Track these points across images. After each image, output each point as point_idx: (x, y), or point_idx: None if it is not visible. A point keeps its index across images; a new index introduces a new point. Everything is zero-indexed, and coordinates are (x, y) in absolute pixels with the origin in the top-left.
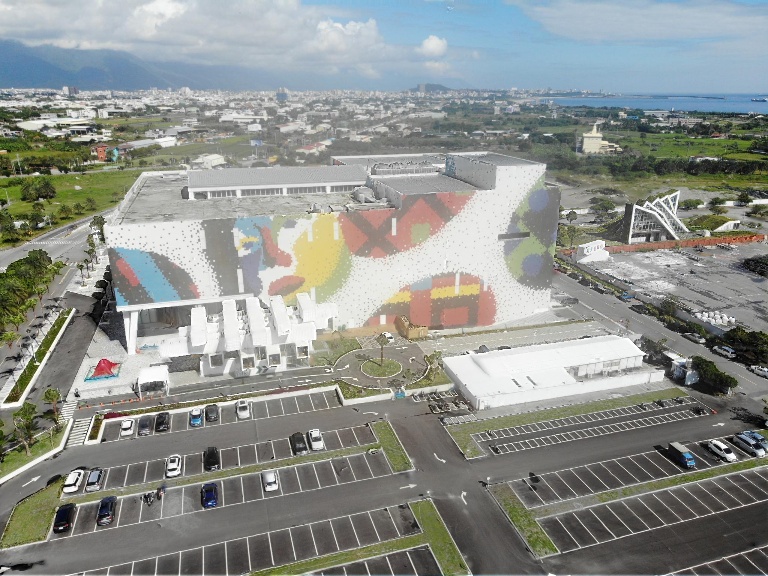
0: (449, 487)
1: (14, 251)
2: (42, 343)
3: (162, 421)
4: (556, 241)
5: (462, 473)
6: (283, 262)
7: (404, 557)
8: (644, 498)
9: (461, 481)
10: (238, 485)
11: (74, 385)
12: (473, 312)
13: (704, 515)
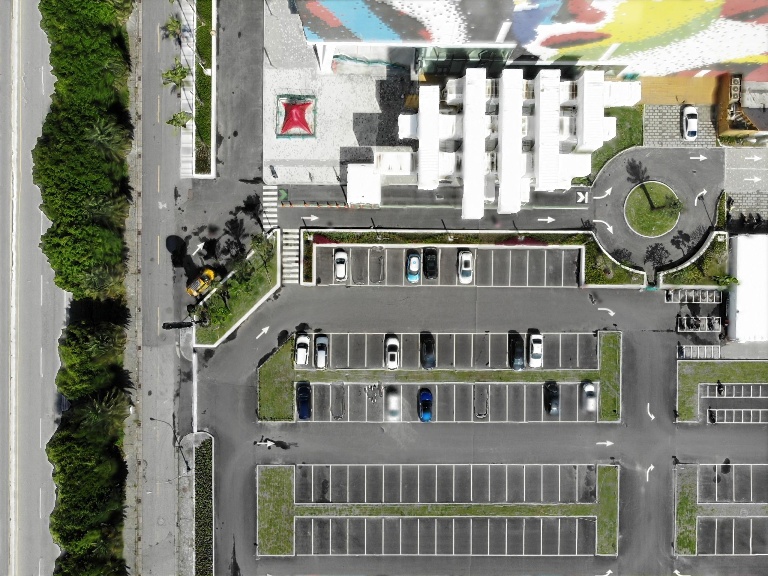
0: (642, 455)
1: None
2: (197, 1)
3: (378, 275)
4: None
5: (662, 440)
6: (587, 18)
7: (573, 523)
8: None
9: (656, 451)
10: (451, 396)
11: (265, 143)
12: None
13: None
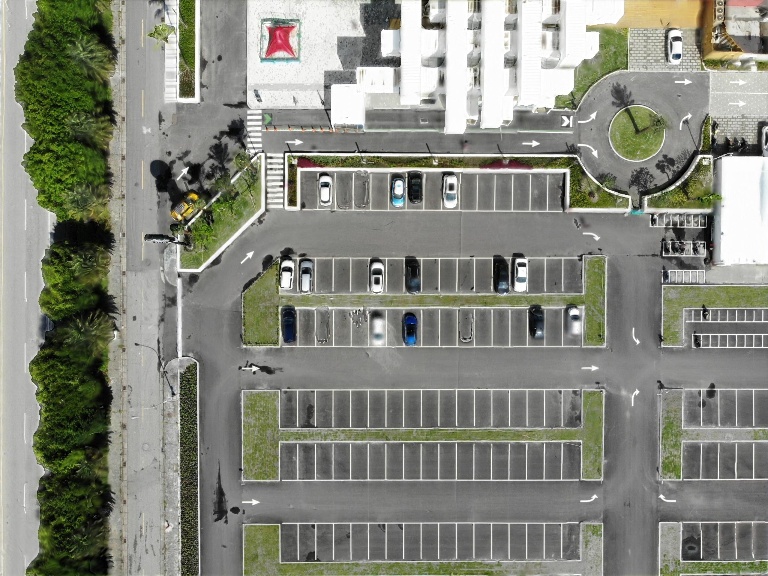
0: (627, 380)
1: None
2: None
3: (362, 198)
4: None
5: (648, 365)
6: None
7: (558, 448)
8: None
9: (642, 375)
10: (436, 321)
11: (249, 67)
12: None
13: None
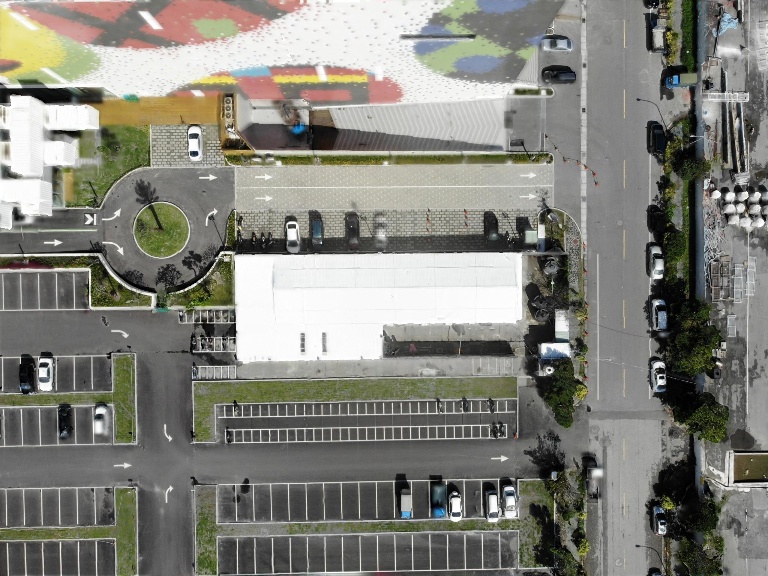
0: (160, 477)
1: None
2: None
3: None
4: None
5: (180, 461)
6: None
7: (92, 546)
8: (330, 539)
9: (175, 472)
10: None
11: None
12: (359, 93)
13: (367, 571)
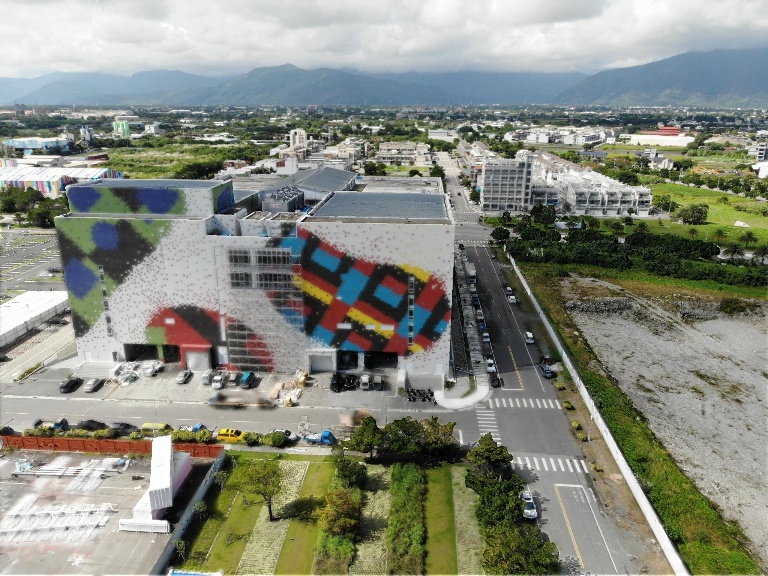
0: None
1: (480, 227)
2: None
3: None
4: None
5: None
6: None
7: None
8: None
9: None
10: None
11: None
12: None
13: None
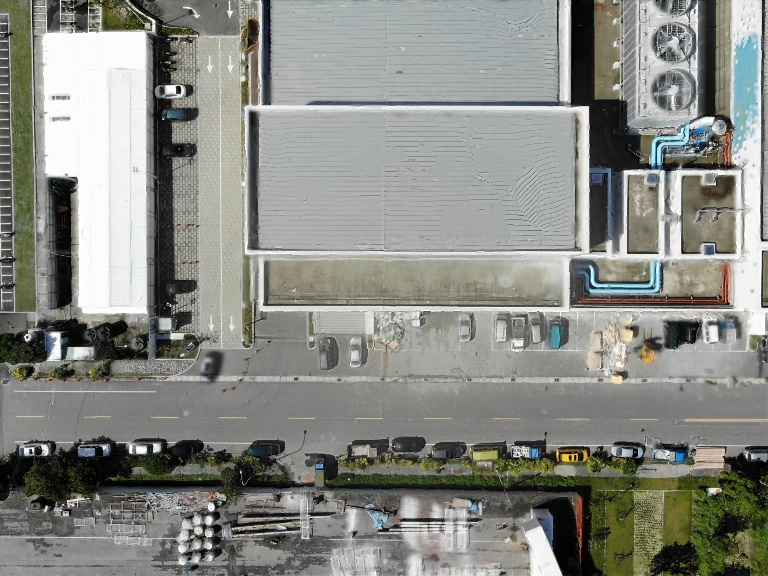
0: None
1: None
2: None
3: None
4: (697, 568)
5: None
6: None
7: None
8: None
9: None
10: None
11: None
12: None
13: None
